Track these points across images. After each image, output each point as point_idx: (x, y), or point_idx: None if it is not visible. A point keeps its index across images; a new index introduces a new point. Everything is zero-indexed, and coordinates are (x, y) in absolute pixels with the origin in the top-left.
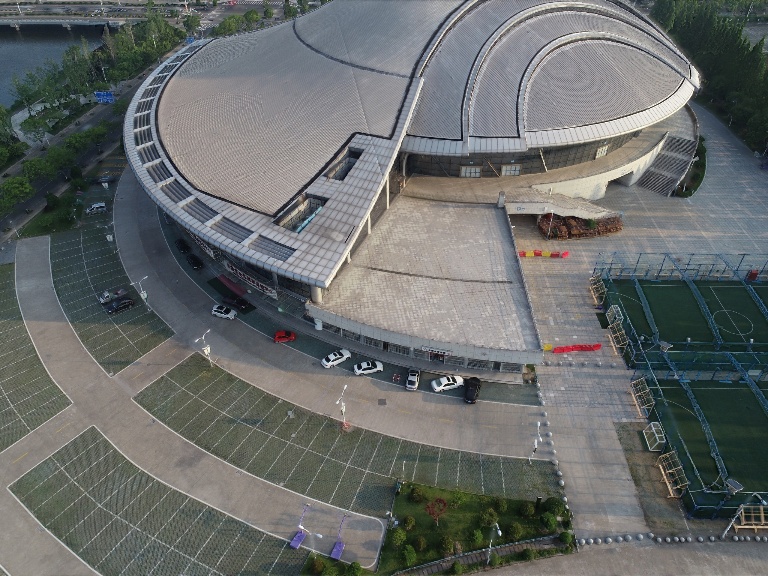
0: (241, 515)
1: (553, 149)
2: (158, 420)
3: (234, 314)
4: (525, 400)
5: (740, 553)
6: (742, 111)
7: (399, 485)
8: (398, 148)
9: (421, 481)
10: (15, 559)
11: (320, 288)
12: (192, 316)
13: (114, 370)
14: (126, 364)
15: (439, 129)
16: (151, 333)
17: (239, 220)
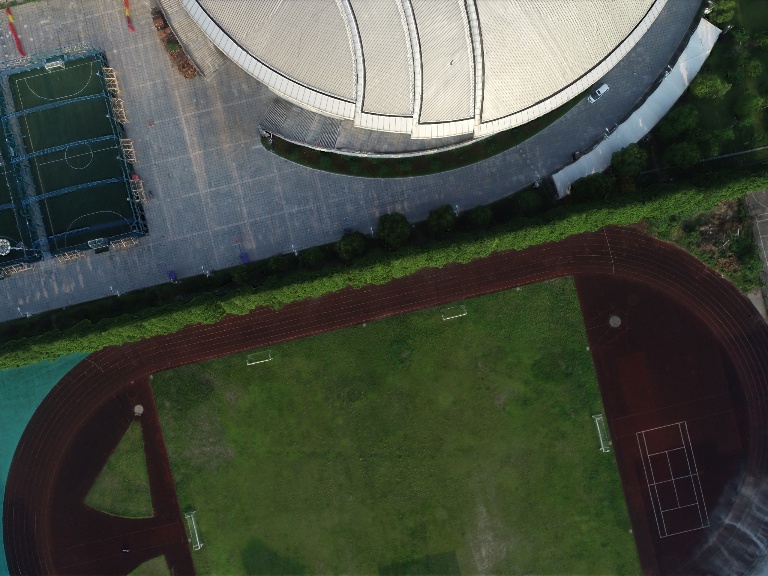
0: None
1: None
2: None
3: None
4: None
5: None
6: (433, 214)
7: None
8: None
9: None
10: None
11: None
12: None
13: None
14: None
15: None
16: None
17: None
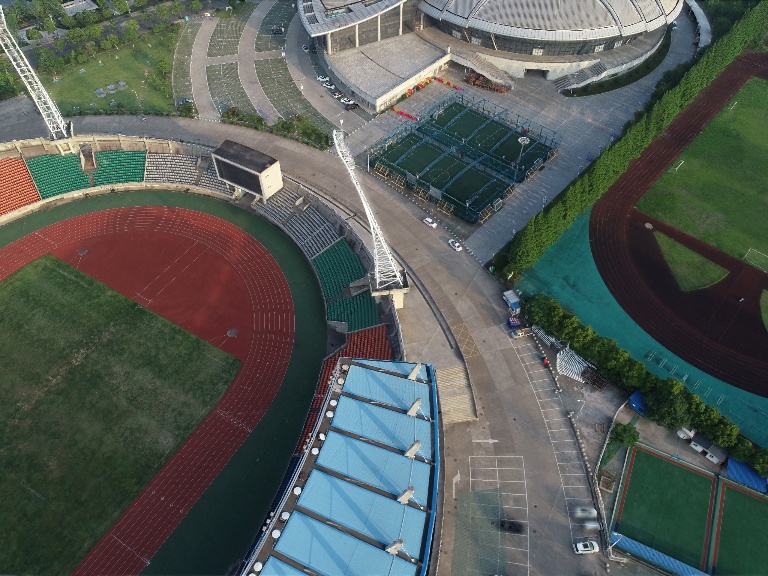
0: (252, 100)
1: (501, 37)
2: (255, 69)
3: (308, 51)
4: (366, 118)
5: (367, 177)
6: None
7: (297, 114)
8: (402, 2)
9: (306, 118)
10: (195, 81)
11: (330, 47)
12: (296, 46)
13: (257, 51)
14: (262, 51)
15: (437, 2)
16: (278, 45)
17: (315, 6)
